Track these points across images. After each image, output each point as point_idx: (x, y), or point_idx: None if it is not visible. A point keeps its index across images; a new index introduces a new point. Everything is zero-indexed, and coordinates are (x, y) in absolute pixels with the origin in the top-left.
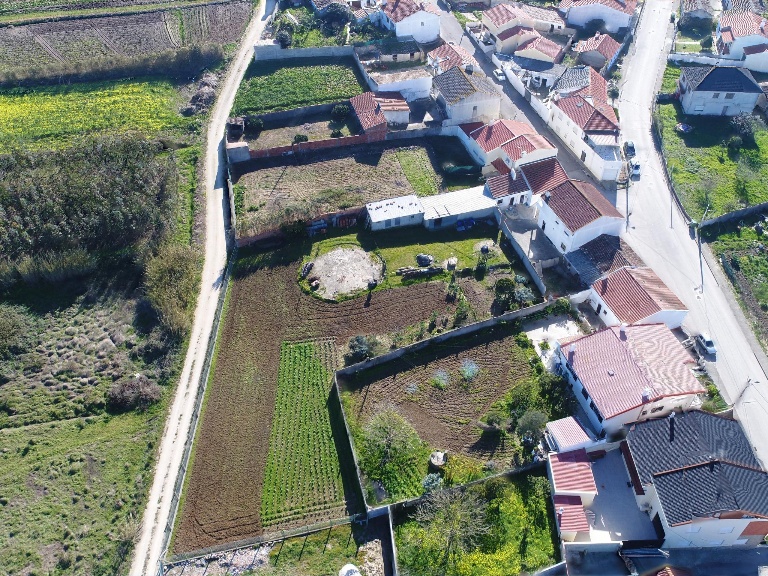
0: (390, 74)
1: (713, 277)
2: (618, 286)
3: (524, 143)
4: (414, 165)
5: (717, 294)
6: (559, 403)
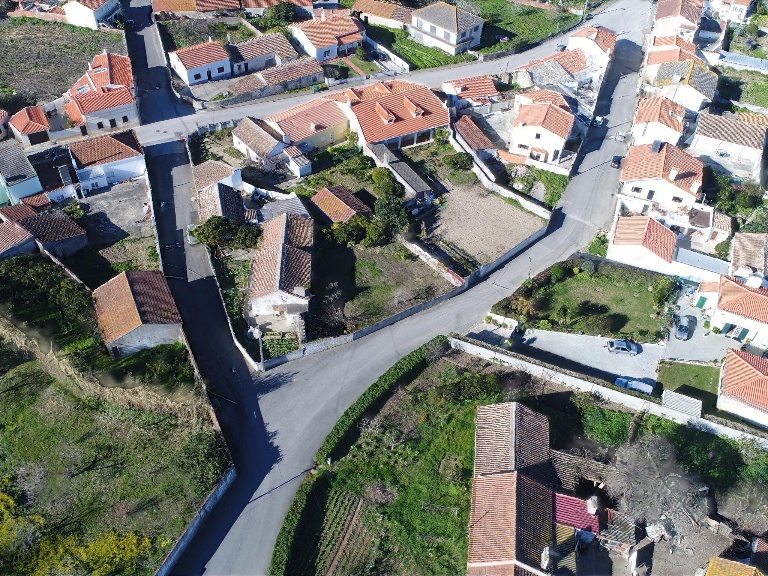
0: (739, 143)
1: (608, 8)
2: (692, 2)
3: (680, 42)
4: (759, 99)
5: (617, 5)
6: (763, 3)
